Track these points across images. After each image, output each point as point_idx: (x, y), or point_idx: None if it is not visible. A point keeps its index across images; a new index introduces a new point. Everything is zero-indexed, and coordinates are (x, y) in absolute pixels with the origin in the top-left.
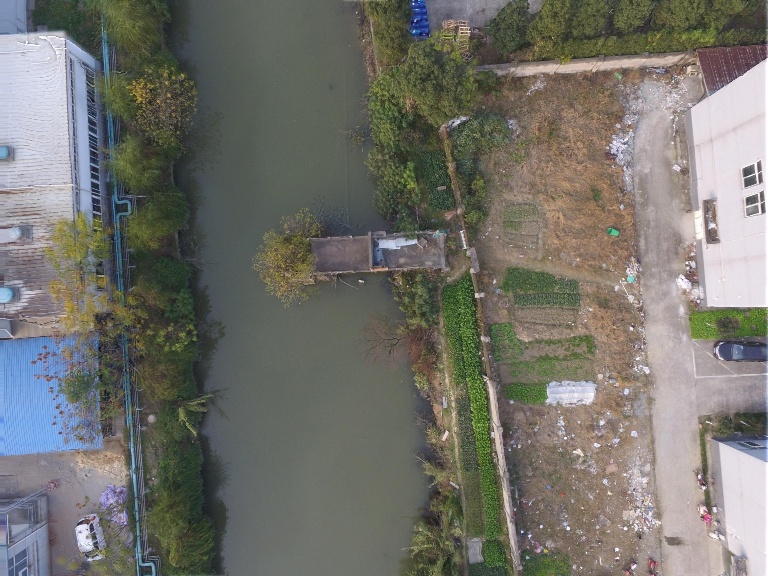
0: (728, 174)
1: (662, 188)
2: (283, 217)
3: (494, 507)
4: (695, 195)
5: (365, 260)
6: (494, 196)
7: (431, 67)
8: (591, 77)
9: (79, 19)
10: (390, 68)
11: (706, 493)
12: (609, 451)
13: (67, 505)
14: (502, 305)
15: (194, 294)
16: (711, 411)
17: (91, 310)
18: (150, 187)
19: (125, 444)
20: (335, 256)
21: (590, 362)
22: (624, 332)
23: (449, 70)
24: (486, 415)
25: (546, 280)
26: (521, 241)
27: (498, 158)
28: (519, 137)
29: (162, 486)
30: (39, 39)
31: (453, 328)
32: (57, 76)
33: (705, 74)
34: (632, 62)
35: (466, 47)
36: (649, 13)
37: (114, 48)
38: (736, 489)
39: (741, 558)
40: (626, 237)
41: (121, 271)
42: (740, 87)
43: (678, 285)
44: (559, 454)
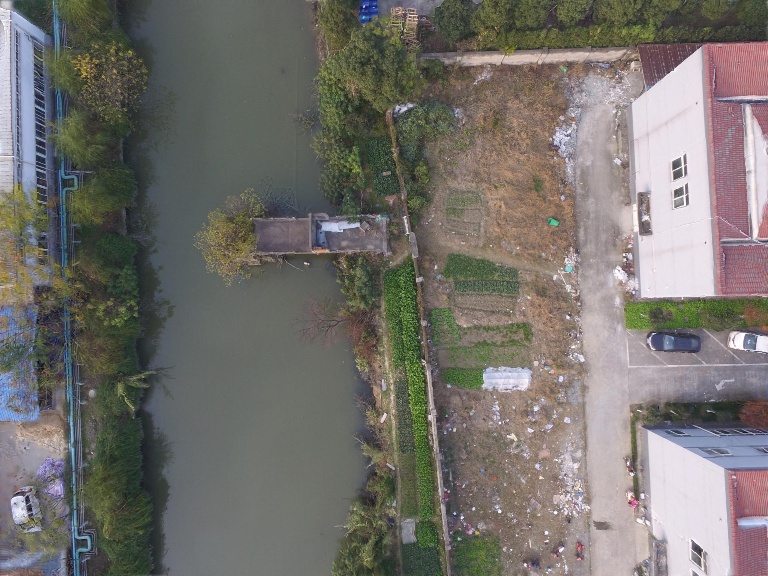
0: (660, 167)
1: (603, 181)
2: None
3: (428, 489)
4: (633, 188)
5: (308, 242)
6: (438, 183)
7: (371, 51)
8: (537, 69)
9: None
10: (336, 52)
11: (635, 480)
12: (542, 436)
13: (5, 477)
14: (442, 291)
15: (139, 271)
16: (642, 400)
17: (31, 283)
18: (95, 162)
19: (64, 418)
20: (278, 237)
21: (526, 349)
22: (560, 320)
23: (389, 55)
24: (423, 398)
25: (486, 267)
26: (463, 228)
27: (443, 146)
28: (465, 126)
29: (99, 460)
30: None
31: (394, 312)
32: (5, 49)
33: (644, 69)
34: (576, 55)
35: (413, 35)
36: (589, 7)
37: (64, 23)
38: (660, 475)
39: (662, 542)
40: (566, 227)
41: (65, 246)
42: (671, 82)
43: (615, 276)
44: (493, 438)
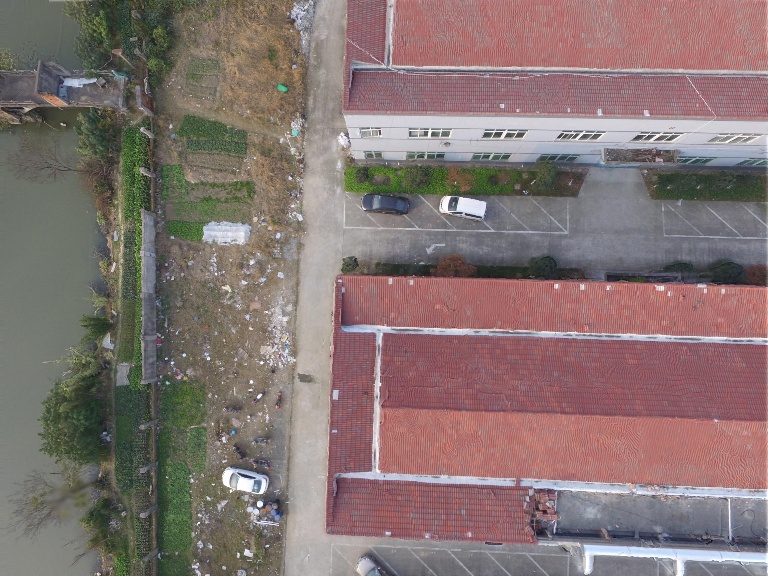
0: None
1: (335, 53)
2: None
3: None
4: None
5: None
6: (182, 51)
7: None
8: None
9: None
10: None
11: None
12: (255, 289)
13: None
14: (175, 148)
15: None
16: None
17: None
18: None
19: None
20: (24, 90)
21: (248, 206)
22: (282, 180)
23: None
24: None
25: (217, 128)
26: (200, 92)
27: (190, 17)
28: None
29: None
30: None
31: (127, 166)
32: None
33: None
34: None
35: None
36: None
37: None
38: None
39: None
40: (295, 95)
41: None
42: None
43: (338, 142)
44: (209, 288)
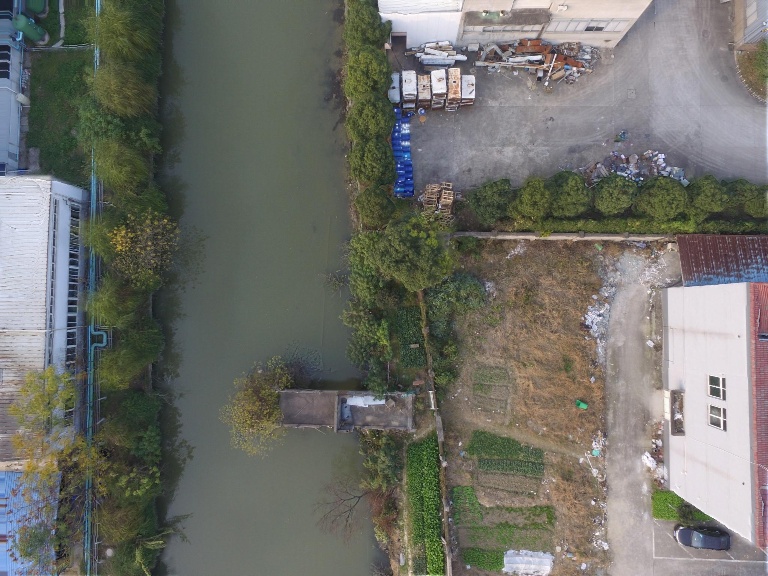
0: (696, 373)
1: (634, 363)
2: None
3: None
4: (666, 375)
5: (332, 415)
6: (466, 357)
7: (406, 251)
8: (571, 246)
9: (71, 147)
10: (370, 232)
11: None
12: None
13: None
14: (466, 468)
15: (162, 428)
16: None
17: (56, 448)
18: (125, 327)
19: None
20: (303, 408)
21: (549, 533)
22: (585, 506)
23: (424, 254)
24: None
25: (511, 447)
26: (490, 405)
27: (473, 319)
28: (495, 300)
29: None
30: (30, 163)
31: (415, 487)
32: (43, 207)
33: (682, 262)
34: (612, 238)
35: (448, 211)
36: (628, 206)
37: (102, 181)
38: None
39: None
40: (594, 410)
41: (91, 403)
42: (712, 296)
43: (643, 462)
44: None
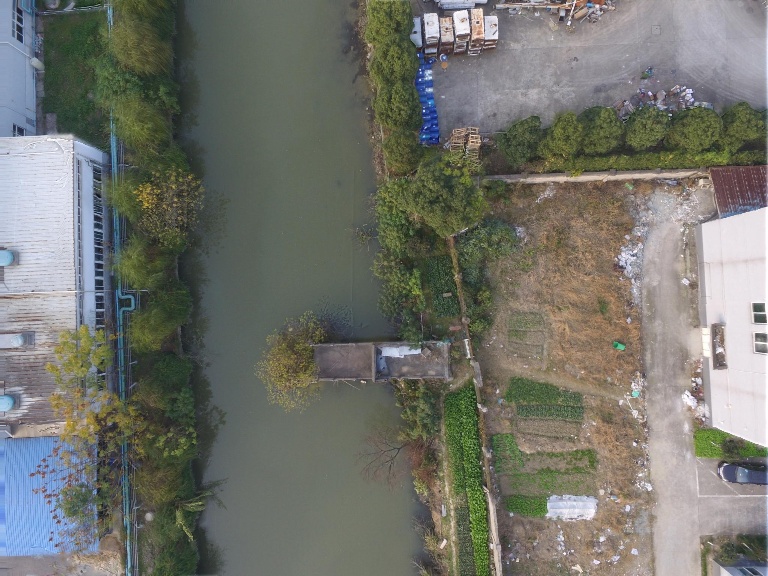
0: (738, 303)
1: (670, 302)
2: (286, 319)
3: None
4: (703, 312)
5: (368, 367)
6: (500, 304)
7: (440, 191)
8: (601, 186)
9: (88, 110)
10: (399, 178)
11: None
12: (608, 568)
13: None
14: (504, 415)
15: (195, 390)
16: (713, 531)
17: (91, 412)
18: (154, 288)
19: (121, 542)
20: (338, 362)
21: (592, 477)
22: (627, 448)
23: (458, 193)
24: (485, 526)
25: (550, 392)
26: (526, 351)
27: (505, 265)
28: (527, 245)
29: None
30: (48, 129)
31: (454, 437)
32: (64, 171)
33: (717, 195)
34: (643, 175)
35: (476, 156)
36: (662, 137)
37: (122, 143)
38: None
39: None
40: (632, 351)
41: (122, 368)
42: (753, 221)
43: (683, 401)
44: (558, 569)
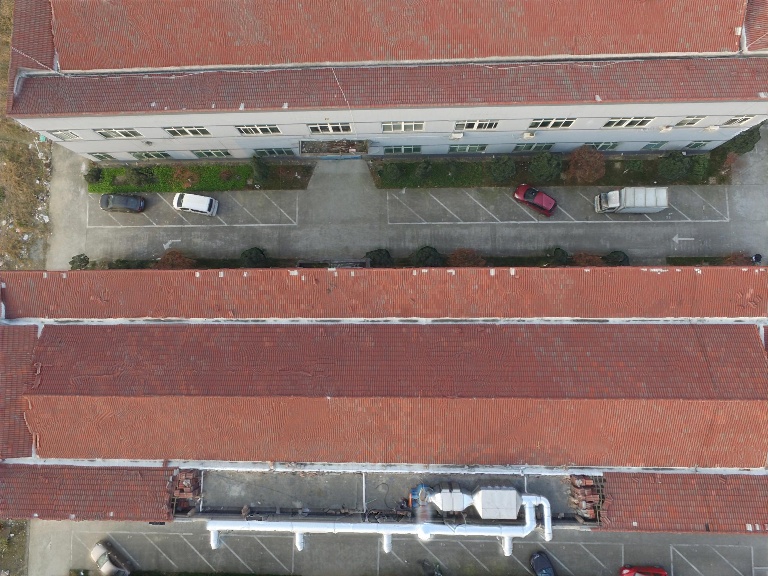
0: None
1: None
2: None
3: None
4: None
5: None
6: None
7: None
8: None
9: None
10: None
11: None
12: None
13: None
14: None
15: None
16: (96, 257)
17: None
18: None
19: None
20: None
21: None
22: (29, 184)
23: None
24: None
25: None
26: None
27: None
28: None
29: None
30: None
31: None
32: None
33: None
34: None
35: None
36: None
37: None
38: None
39: None
40: None
41: None
42: None
43: None
44: None
